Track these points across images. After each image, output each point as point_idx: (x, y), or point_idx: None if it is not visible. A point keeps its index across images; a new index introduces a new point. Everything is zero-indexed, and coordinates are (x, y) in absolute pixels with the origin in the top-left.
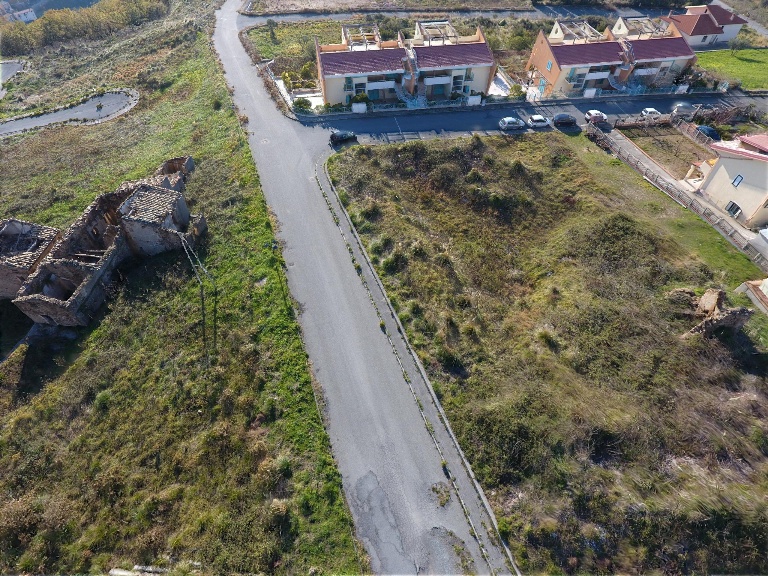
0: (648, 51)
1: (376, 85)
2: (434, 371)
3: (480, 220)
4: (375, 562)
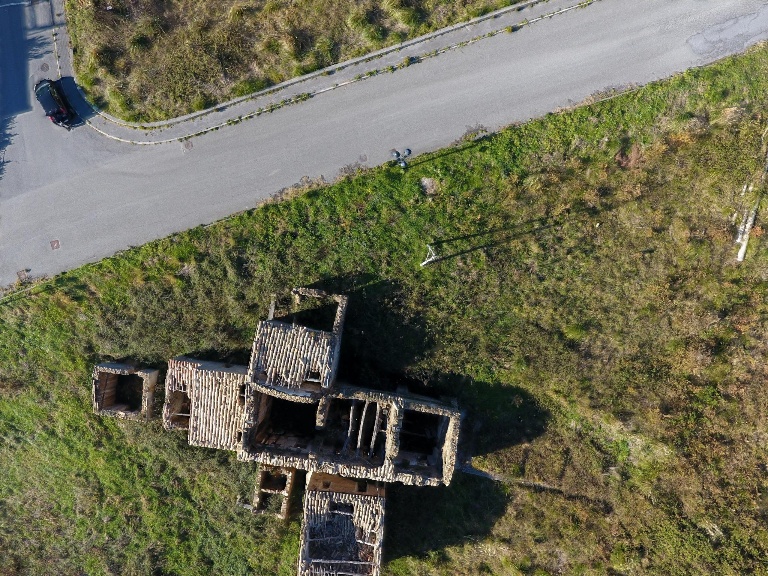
0: None
1: None
2: None
3: None
4: (763, 36)
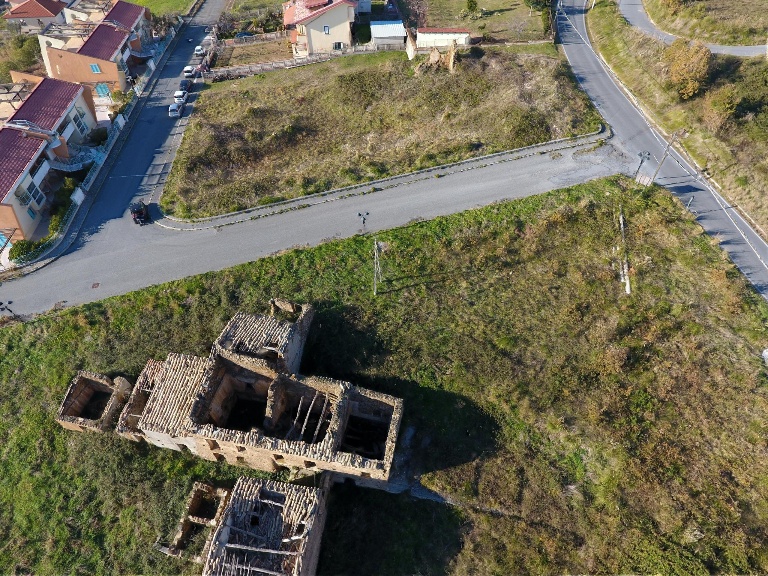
0: (124, 20)
1: (38, 177)
2: (479, 153)
3: (308, 144)
4: (595, 177)
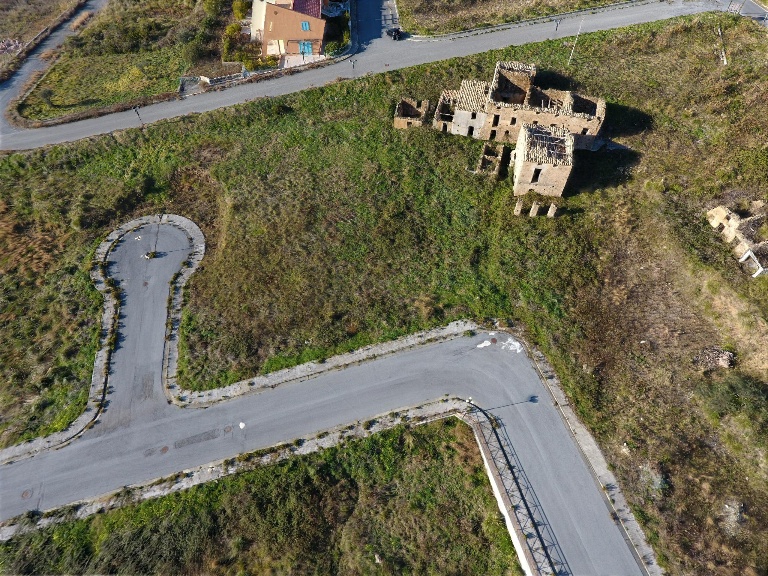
0: None
1: None
2: None
3: None
4: None
